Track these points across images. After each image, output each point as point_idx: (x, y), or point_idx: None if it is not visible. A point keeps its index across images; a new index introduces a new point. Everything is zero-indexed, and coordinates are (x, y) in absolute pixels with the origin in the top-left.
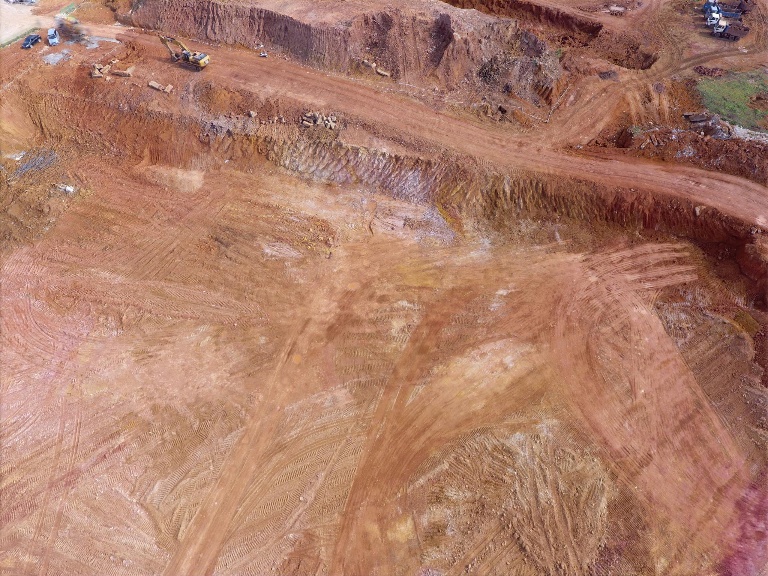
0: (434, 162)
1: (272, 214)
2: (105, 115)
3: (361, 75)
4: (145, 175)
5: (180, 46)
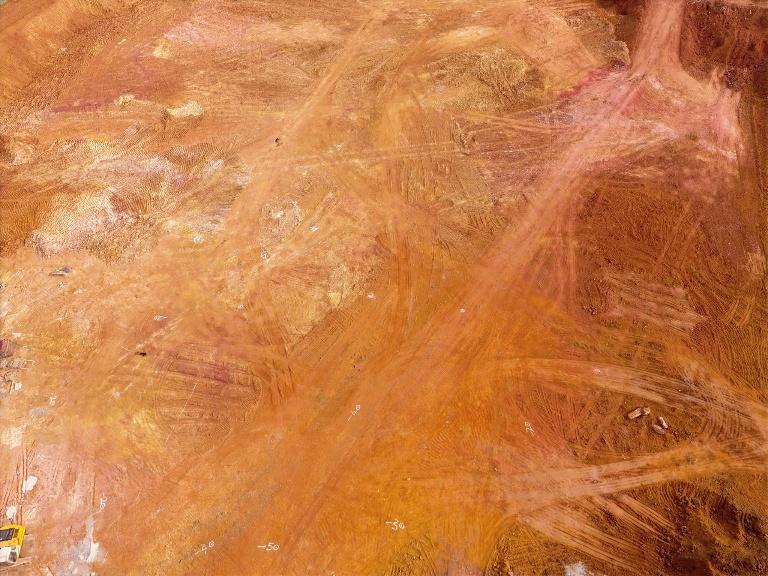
0: None
1: None
2: None
3: None
4: None
5: None
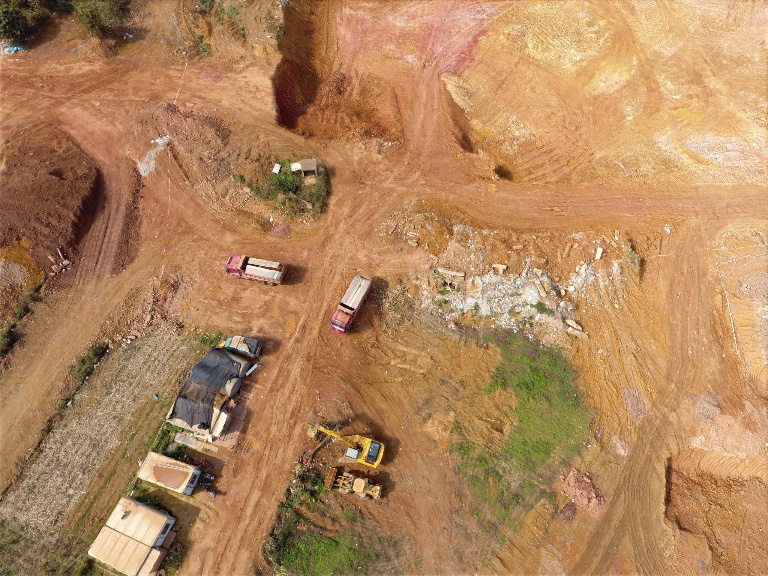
0: (762, 166)
1: None
2: None
3: None
4: None
5: None
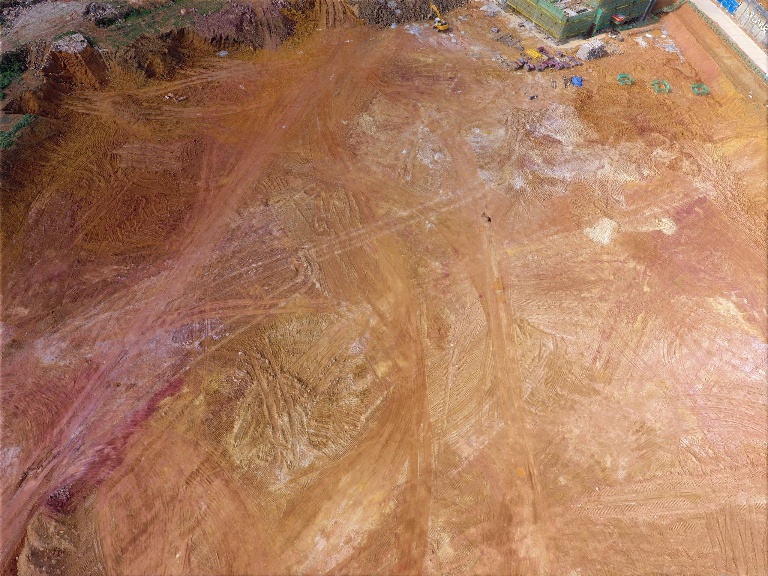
0: None
1: None
2: None
3: None
4: None
5: None
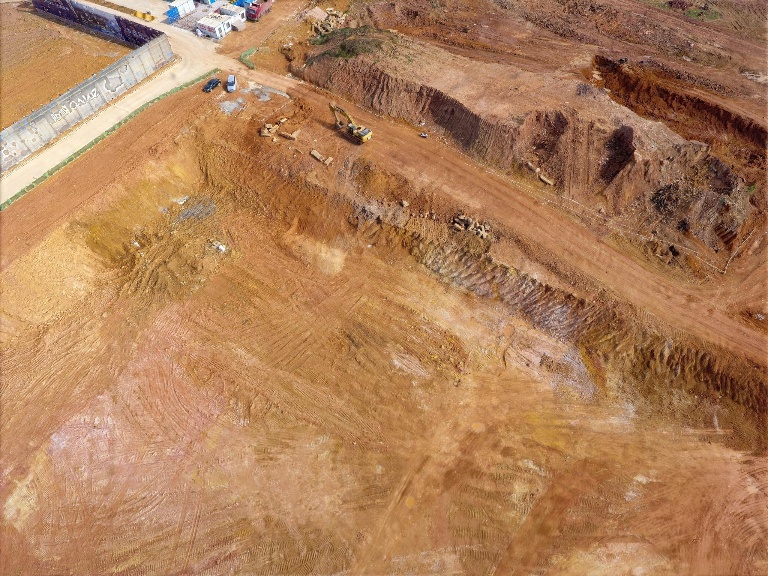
0: (588, 303)
1: (406, 318)
2: (265, 176)
3: (522, 178)
4: (291, 248)
5: (347, 118)
